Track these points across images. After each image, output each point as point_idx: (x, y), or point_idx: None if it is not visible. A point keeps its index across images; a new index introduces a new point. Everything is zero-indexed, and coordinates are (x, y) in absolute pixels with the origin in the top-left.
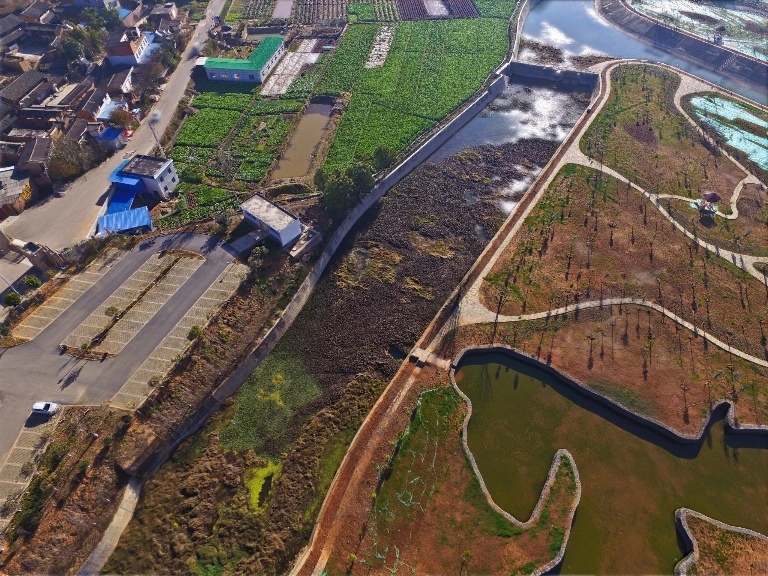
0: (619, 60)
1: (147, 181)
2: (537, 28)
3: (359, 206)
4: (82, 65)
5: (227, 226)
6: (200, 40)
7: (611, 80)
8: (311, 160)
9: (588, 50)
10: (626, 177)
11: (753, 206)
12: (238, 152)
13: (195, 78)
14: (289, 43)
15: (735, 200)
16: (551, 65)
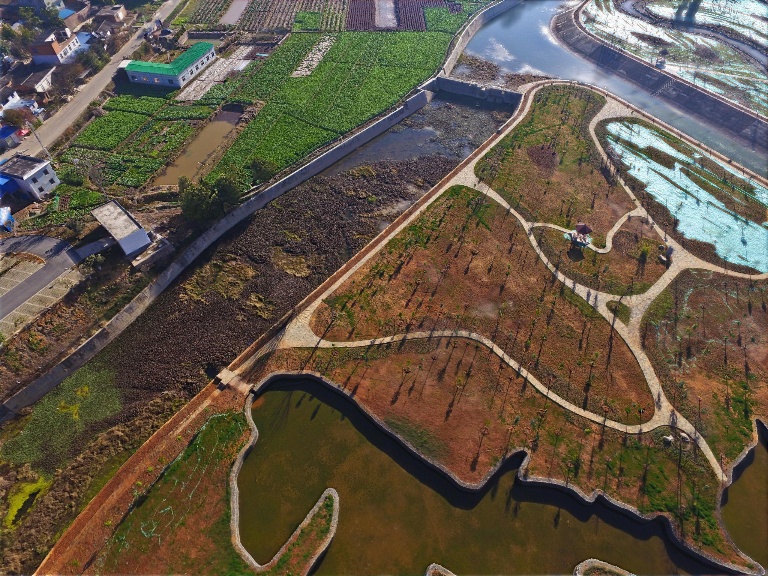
0: (549, 80)
1: (19, 181)
2: (483, 44)
3: (228, 218)
4: (6, 63)
5: (79, 231)
6: (136, 43)
7: (533, 100)
8: (199, 168)
9: (526, 68)
10: (508, 202)
11: (630, 240)
12: (129, 156)
13: (117, 80)
14: (224, 49)
15: (613, 233)
16: (476, 82)
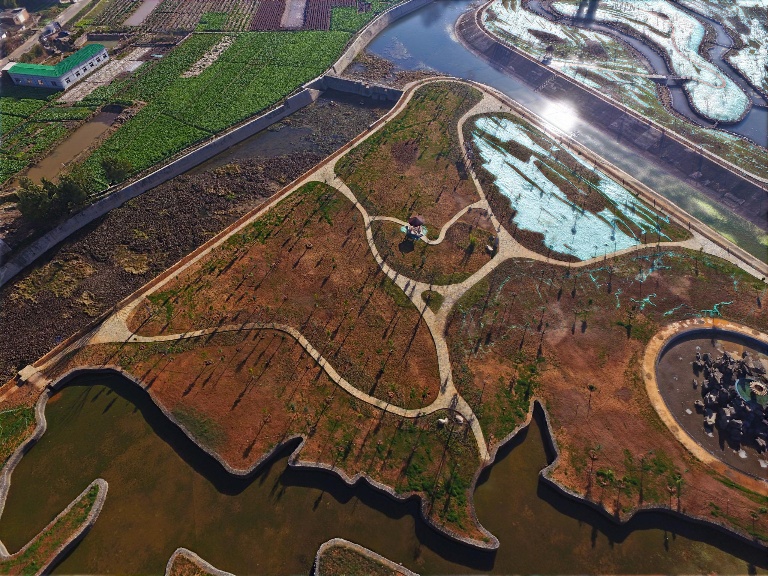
0: (433, 77)
1: None
2: (385, 42)
3: (77, 217)
4: None
5: None
6: (31, 45)
7: (412, 97)
8: None
9: (420, 66)
10: (357, 197)
11: (464, 232)
12: None
13: (0, 83)
14: (119, 51)
15: (449, 225)
16: (360, 80)
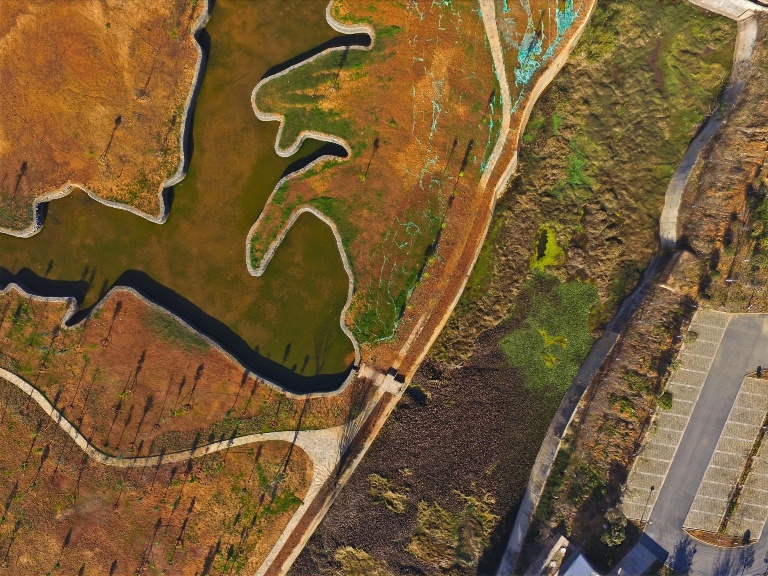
0: None
1: None
2: None
3: None
4: None
5: None
6: None
7: None
8: None
9: None
10: None
11: None
12: None
13: None
14: None
15: None
16: None
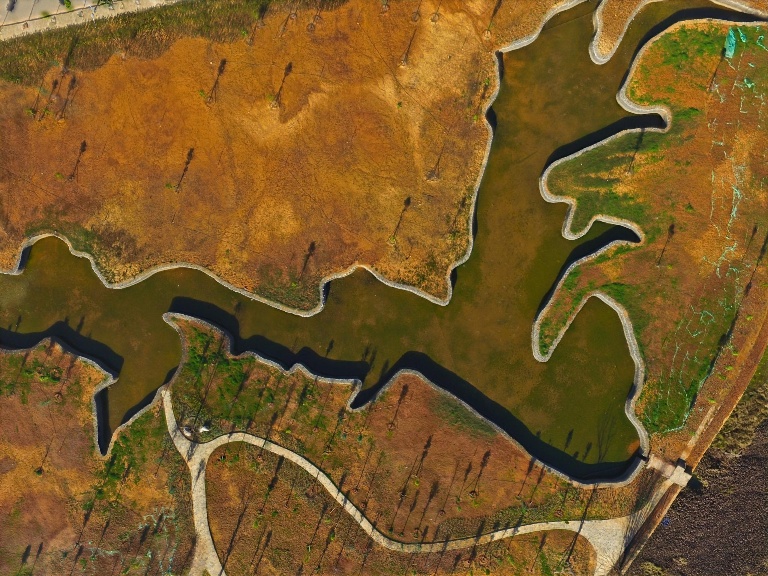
0: None
1: None
2: None
3: None
4: None
5: None
6: None
7: None
8: None
9: None
10: None
11: None
12: None
13: None
14: None
15: None
16: None
